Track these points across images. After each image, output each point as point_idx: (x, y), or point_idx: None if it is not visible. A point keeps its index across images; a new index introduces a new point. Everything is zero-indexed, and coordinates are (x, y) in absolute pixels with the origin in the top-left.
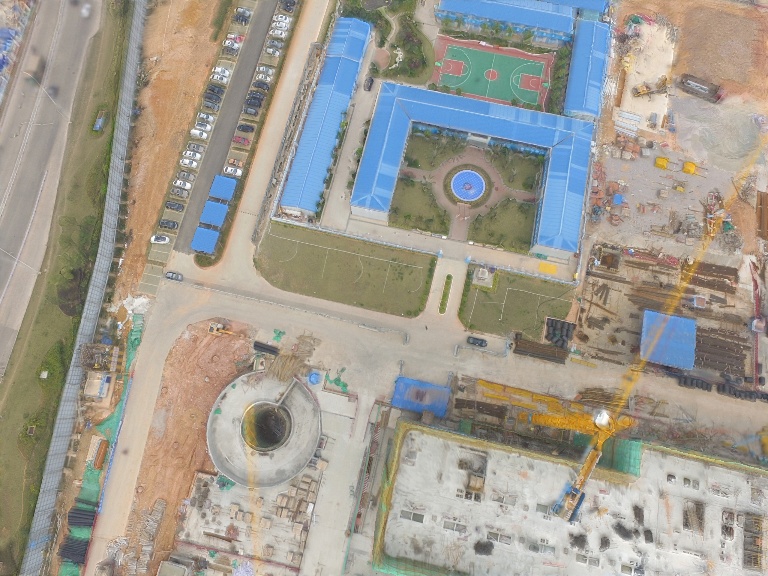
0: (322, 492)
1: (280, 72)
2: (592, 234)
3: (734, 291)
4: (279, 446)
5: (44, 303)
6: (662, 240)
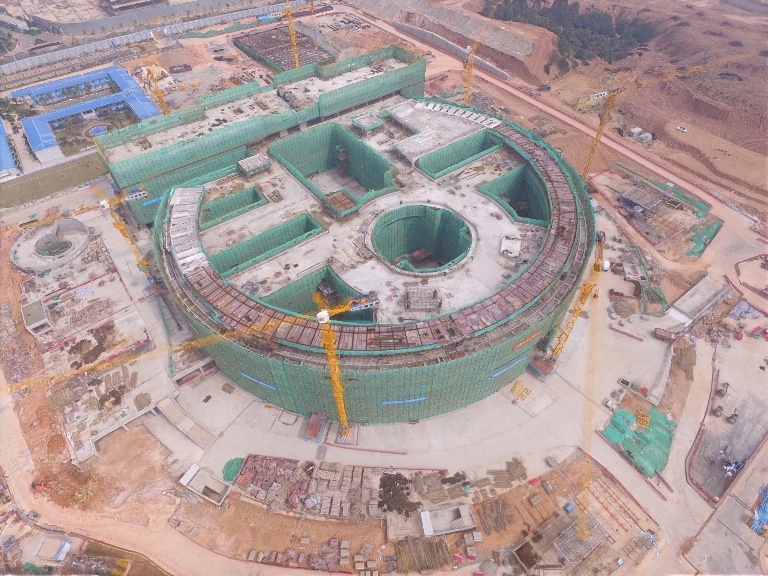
0: (106, 242)
1: None
2: None
3: None
4: (68, 249)
5: None
6: None
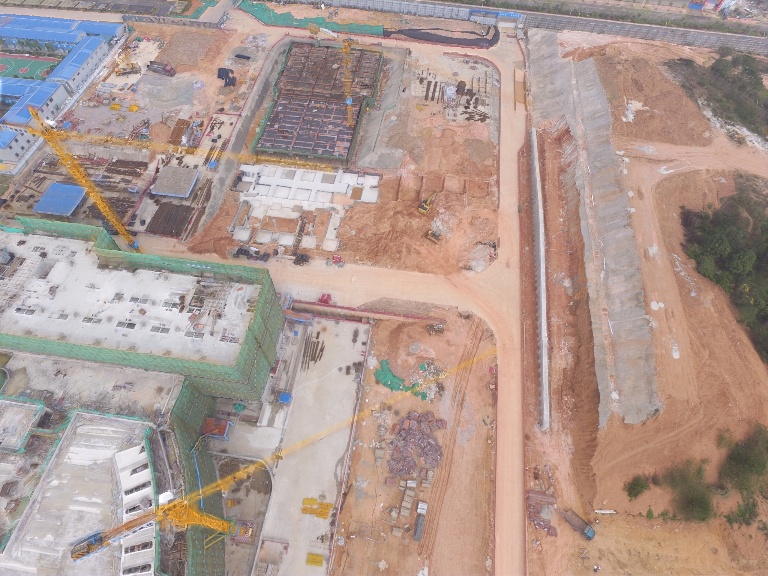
0: None
1: None
2: (45, 147)
3: (140, 175)
4: None
5: None
6: (94, 147)
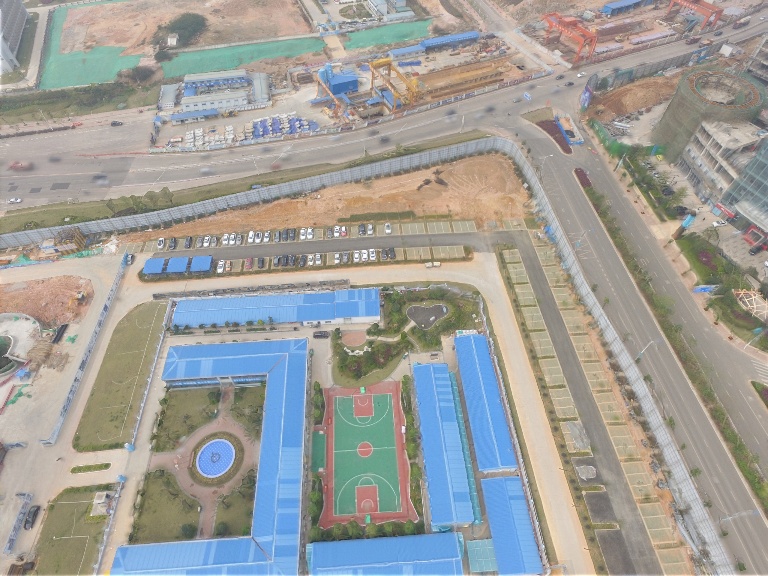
0: None
1: (322, 269)
2: None
3: None
4: None
5: (122, 205)
6: None
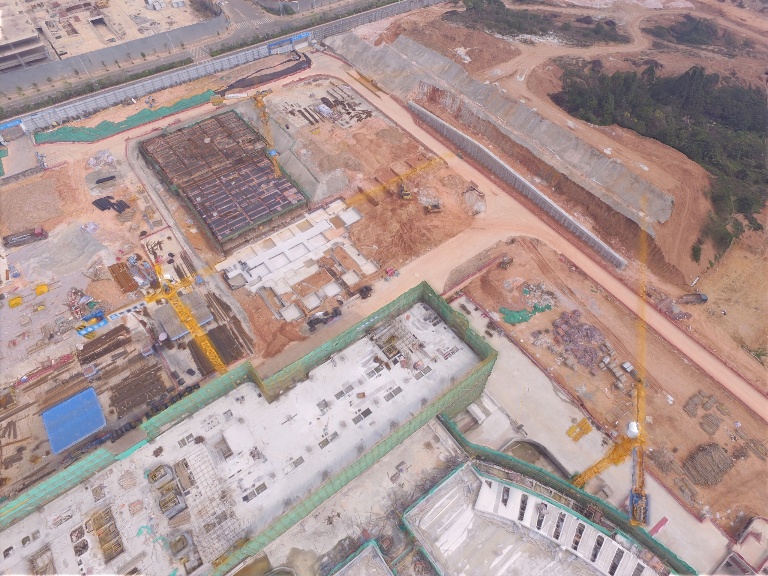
0: None
1: None
2: None
3: (129, 340)
4: None
5: None
6: (42, 352)
